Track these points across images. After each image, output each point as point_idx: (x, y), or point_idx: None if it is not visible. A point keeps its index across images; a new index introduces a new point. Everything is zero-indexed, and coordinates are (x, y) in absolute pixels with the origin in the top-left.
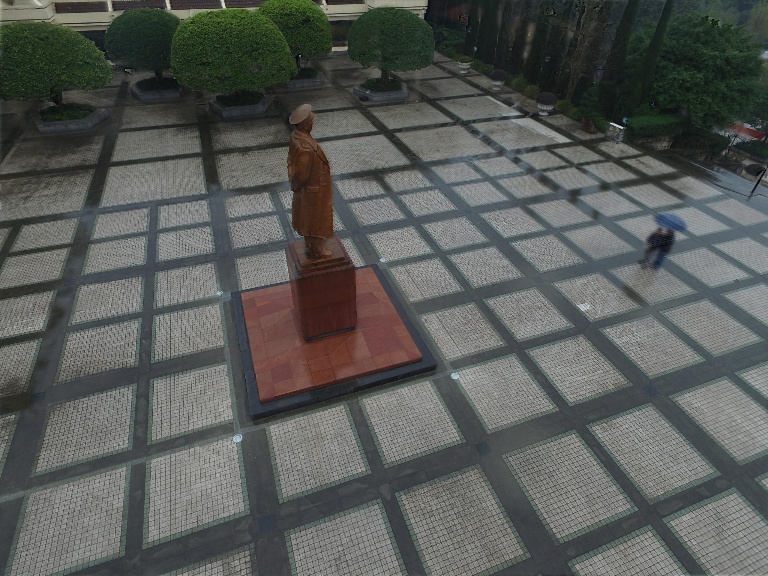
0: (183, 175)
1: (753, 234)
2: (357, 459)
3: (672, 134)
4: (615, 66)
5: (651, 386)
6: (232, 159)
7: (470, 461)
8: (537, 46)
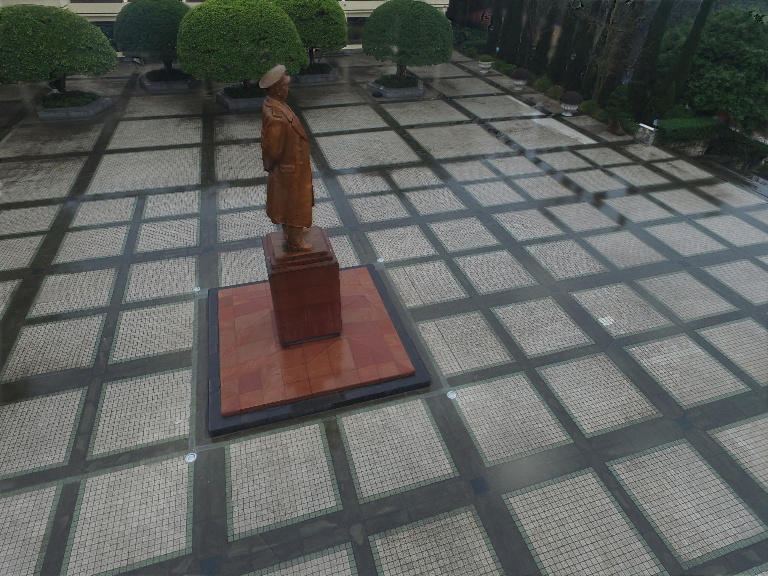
0: (178, 165)
1: None
2: (327, 490)
3: (707, 138)
4: (646, 64)
5: (685, 418)
6: (232, 150)
7: (463, 500)
8: (562, 45)
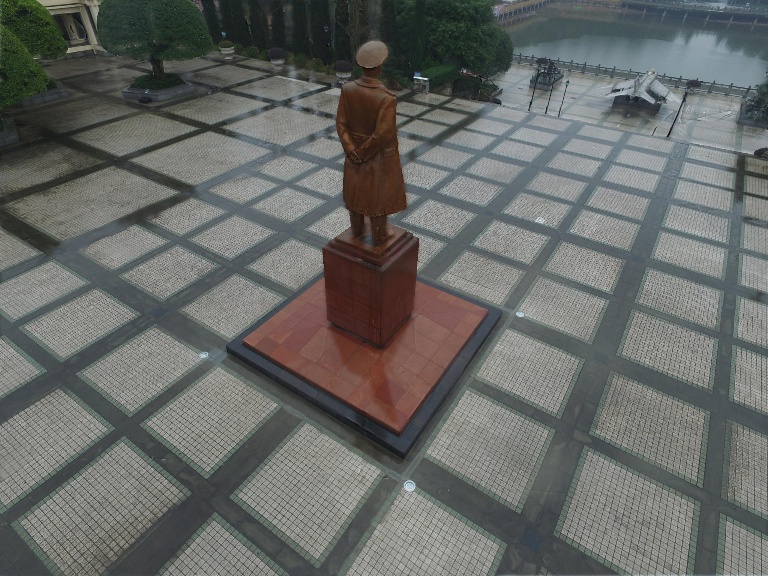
0: None
1: (573, 135)
2: (532, 427)
3: (452, 80)
4: (390, 27)
5: (635, 256)
6: (33, 203)
7: (604, 372)
8: (299, 20)
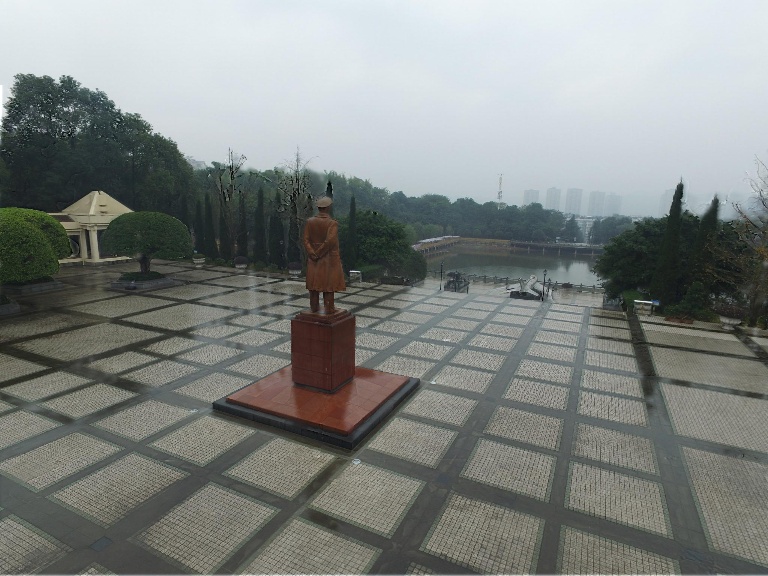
0: None
1: None
2: (443, 431)
3: (379, 276)
4: None
5: (514, 354)
6: (39, 343)
7: (493, 406)
8: (260, 240)
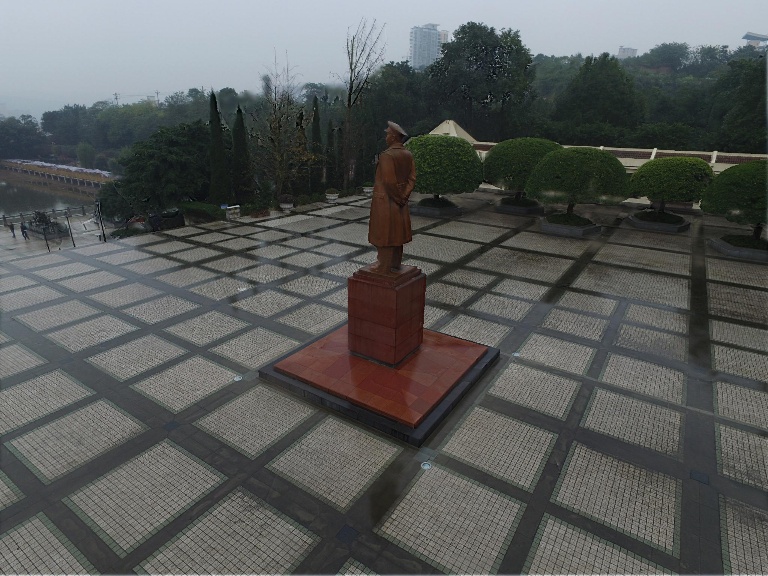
0: None
1: (87, 257)
2: (460, 318)
3: None
4: None
5: (304, 271)
6: None
7: None
8: None
